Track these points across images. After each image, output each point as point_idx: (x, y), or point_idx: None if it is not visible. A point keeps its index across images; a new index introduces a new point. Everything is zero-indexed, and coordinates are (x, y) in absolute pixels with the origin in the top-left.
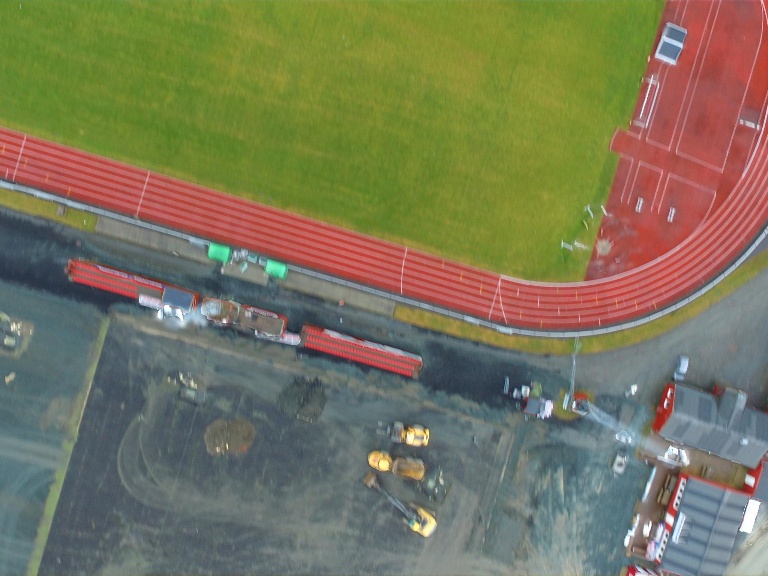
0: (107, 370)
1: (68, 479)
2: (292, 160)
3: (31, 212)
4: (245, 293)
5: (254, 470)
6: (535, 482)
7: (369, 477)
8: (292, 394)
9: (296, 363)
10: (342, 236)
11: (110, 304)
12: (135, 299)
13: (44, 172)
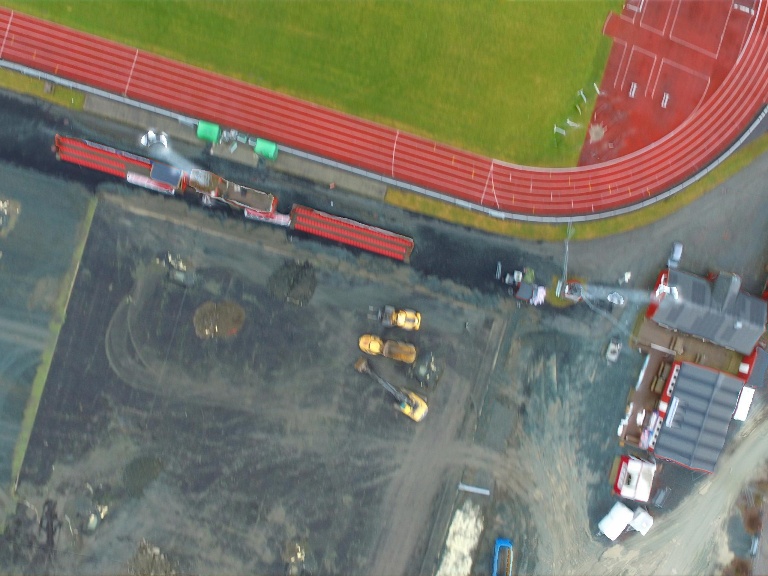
0: (95, 250)
1: (55, 361)
2: (282, 40)
3: (18, 90)
4: (235, 175)
5: (244, 354)
6: (528, 369)
7: (360, 362)
8: (282, 276)
9: (286, 246)
10: (333, 118)
11: (98, 183)
12: (123, 178)
13: (31, 49)
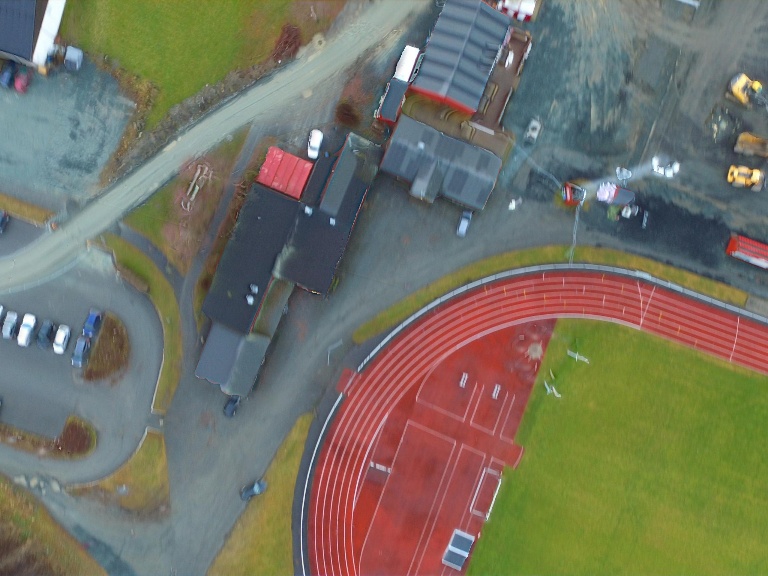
0: None
1: None
2: None
3: None
4: None
5: None
6: (621, 118)
7: None
8: None
9: None
10: None
11: None
12: None
13: None
